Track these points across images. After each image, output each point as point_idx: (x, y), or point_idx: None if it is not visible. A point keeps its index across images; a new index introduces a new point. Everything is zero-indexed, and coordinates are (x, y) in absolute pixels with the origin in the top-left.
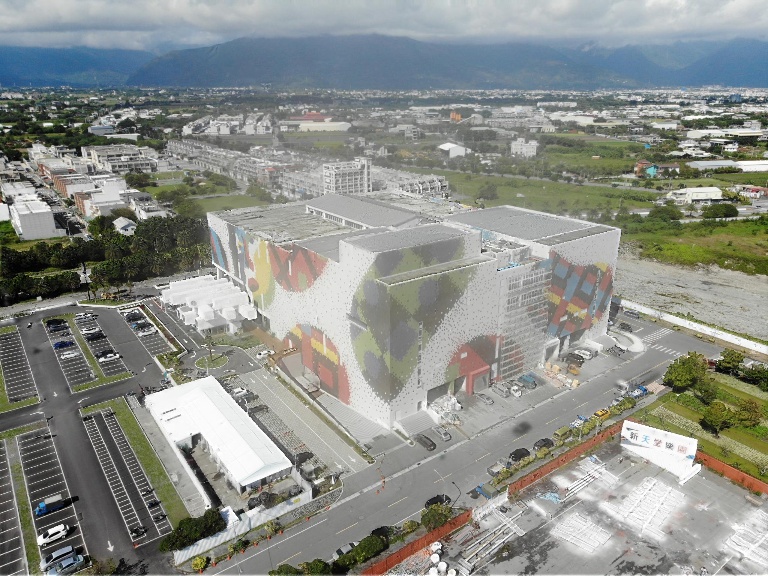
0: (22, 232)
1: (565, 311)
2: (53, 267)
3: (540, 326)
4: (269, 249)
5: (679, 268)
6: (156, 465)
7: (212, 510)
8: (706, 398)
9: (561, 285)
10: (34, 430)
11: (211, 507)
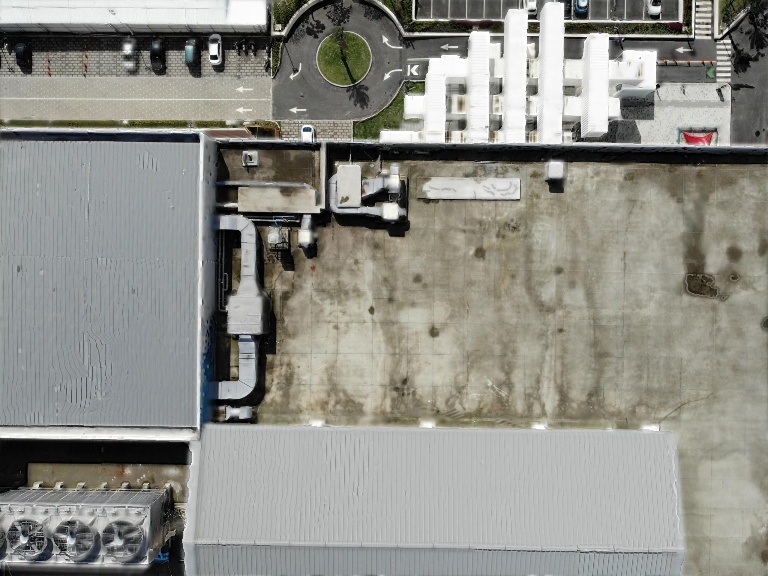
0: None
1: None
2: None
3: None
4: None
5: None
6: None
7: None
8: None
9: None
10: None
11: None
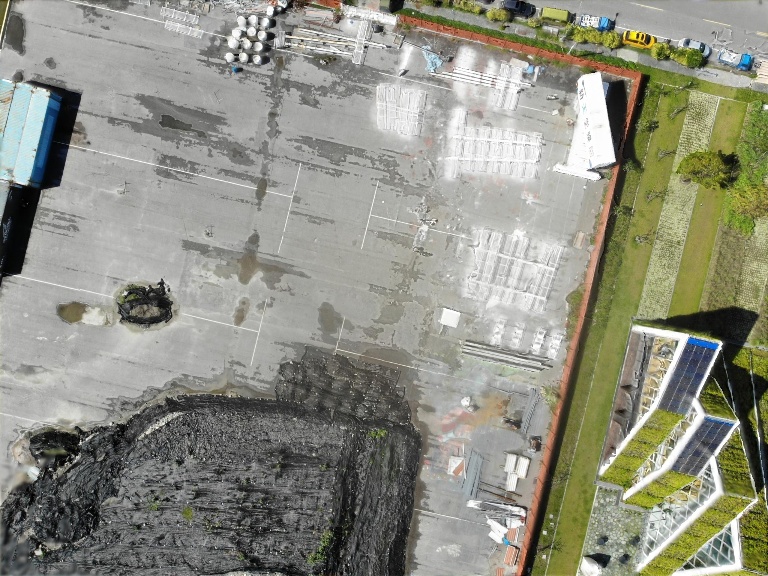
0: None
1: None
2: None
3: None
4: None
5: None
6: None
7: None
8: (761, 143)
9: None
10: None
11: None
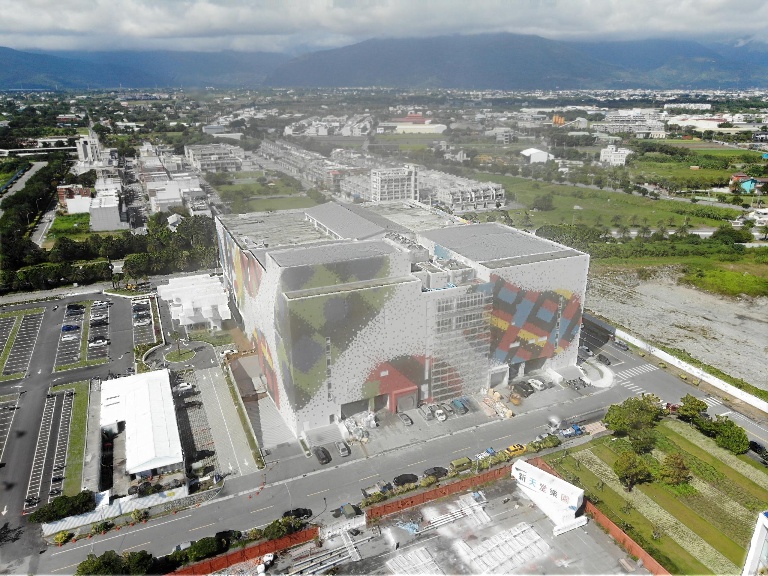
0: (92, 224)
1: (516, 337)
2: (103, 257)
3: (481, 351)
4: (240, 255)
5: (718, 298)
6: (80, 445)
7: (85, 492)
8: (635, 446)
9: (509, 310)
10: (6, 401)
11: (87, 489)
